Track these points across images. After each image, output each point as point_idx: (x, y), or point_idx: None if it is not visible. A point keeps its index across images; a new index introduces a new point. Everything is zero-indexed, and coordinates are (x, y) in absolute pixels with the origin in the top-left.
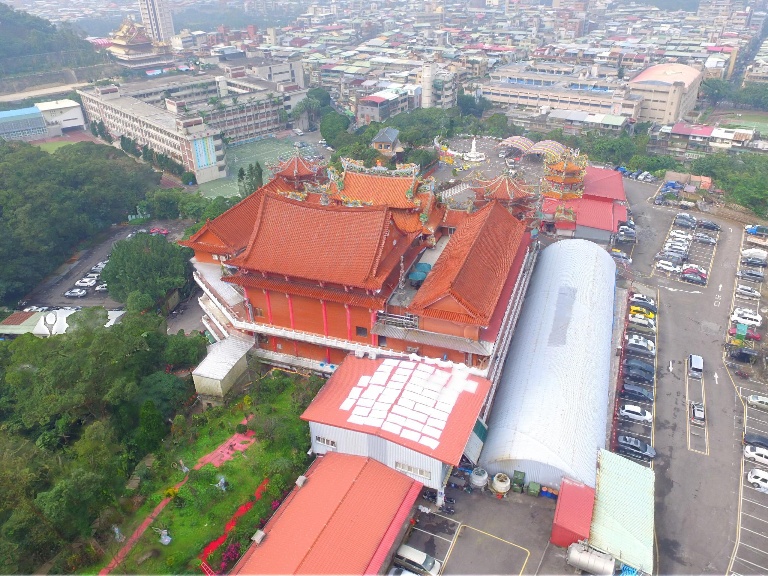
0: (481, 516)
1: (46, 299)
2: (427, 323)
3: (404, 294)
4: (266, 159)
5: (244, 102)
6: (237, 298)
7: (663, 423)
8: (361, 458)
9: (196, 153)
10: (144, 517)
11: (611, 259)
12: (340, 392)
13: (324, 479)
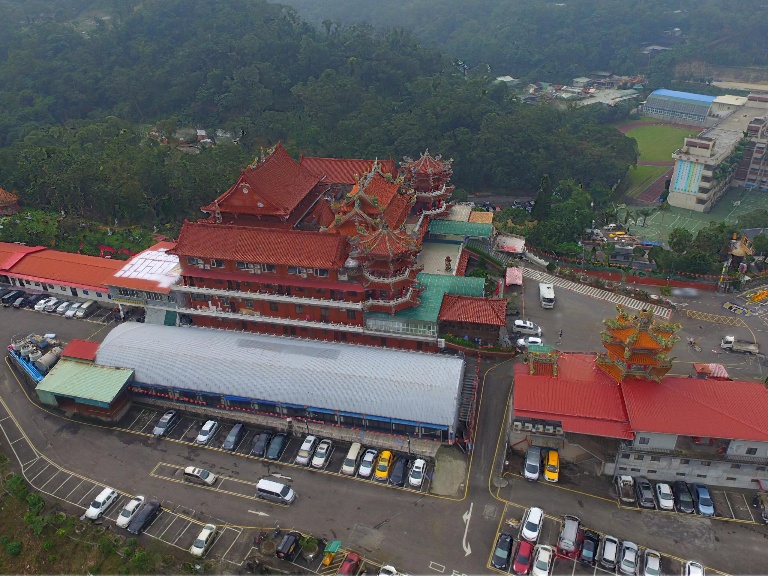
0: (110, 330)
1: None
2: None
3: None
4: None
5: None
6: None
7: (196, 451)
8: None
9: (678, 173)
10: None
11: (447, 410)
12: None
13: None
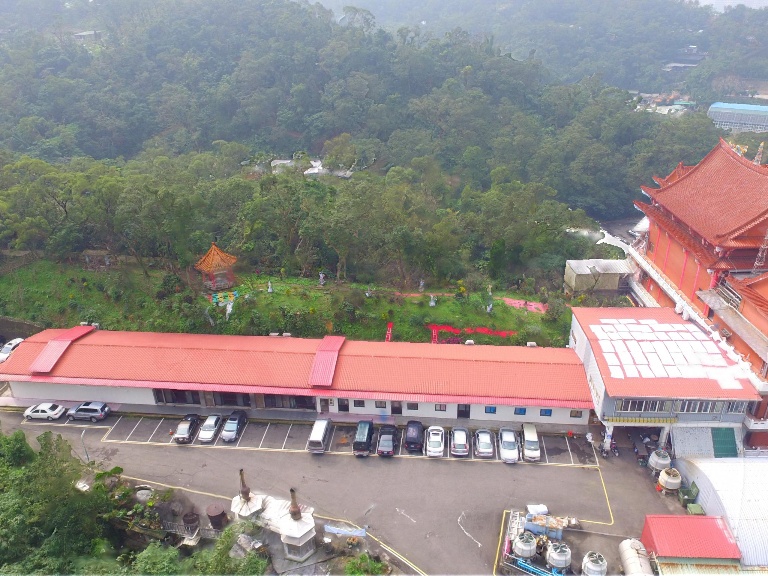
0: (621, 479)
1: (615, 228)
2: (747, 306)
3: (757, 275)
4: None
5: None
6: (645, 228)
7: None
8: (579, 361)
9: None
10: (442, 292)
11: None
12: (620, 315)
13: (542, 352)
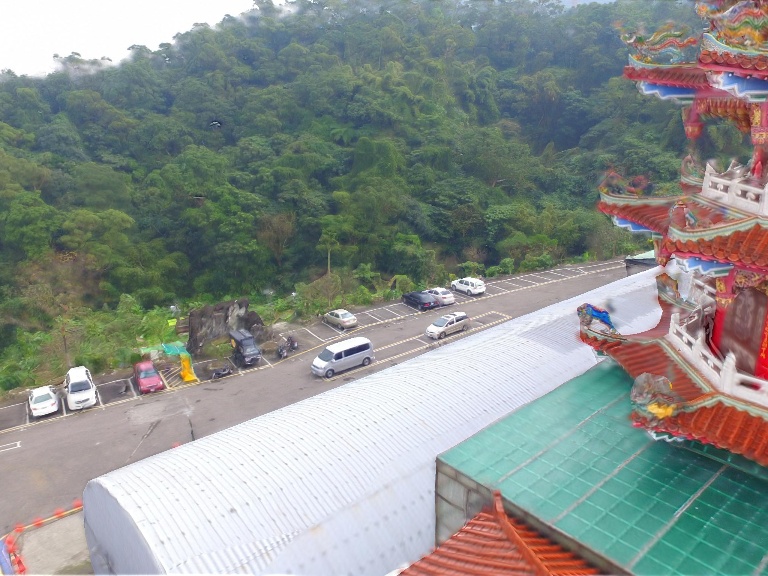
0: None
1: None
2: None
3: None
4: None
5: None
6: None
7: None
8: None
9: None
10: None
11: None
12: None
13: None
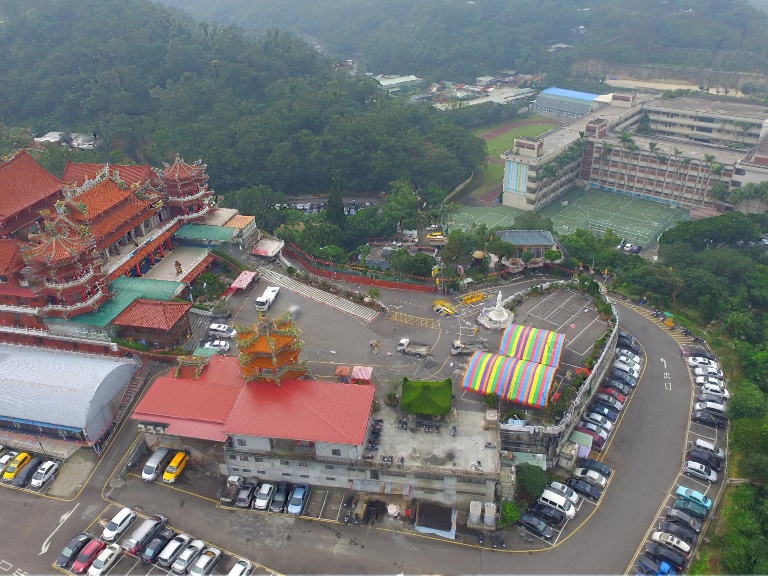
0: None
1: None
2: None
3: None
4: (603, 221)
5: (669, 153)
6: None
7: None
8: None
9: (509, 174)
10: None
11: (81, 413)
12: None
13: None
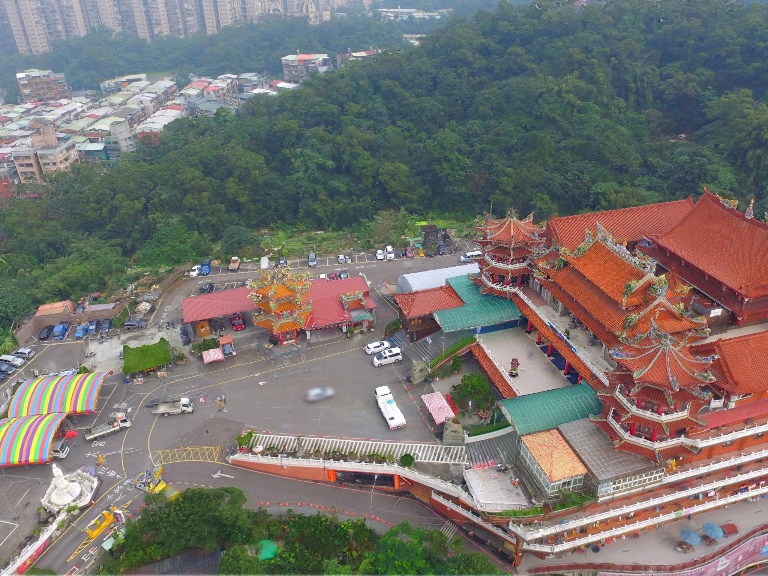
0: None
1: None
2: None
3: None
4: None
5: None
6: None
7: None
8: None
9: None
10: None
11: None
12: None
13: None
